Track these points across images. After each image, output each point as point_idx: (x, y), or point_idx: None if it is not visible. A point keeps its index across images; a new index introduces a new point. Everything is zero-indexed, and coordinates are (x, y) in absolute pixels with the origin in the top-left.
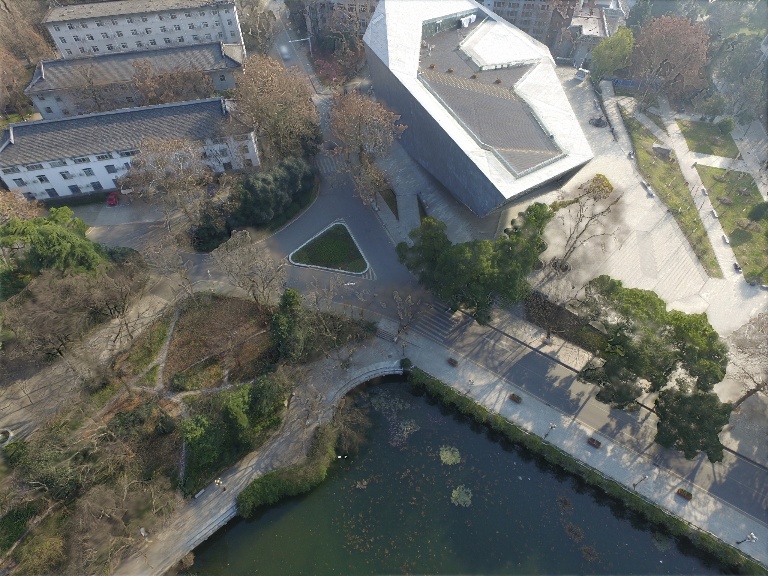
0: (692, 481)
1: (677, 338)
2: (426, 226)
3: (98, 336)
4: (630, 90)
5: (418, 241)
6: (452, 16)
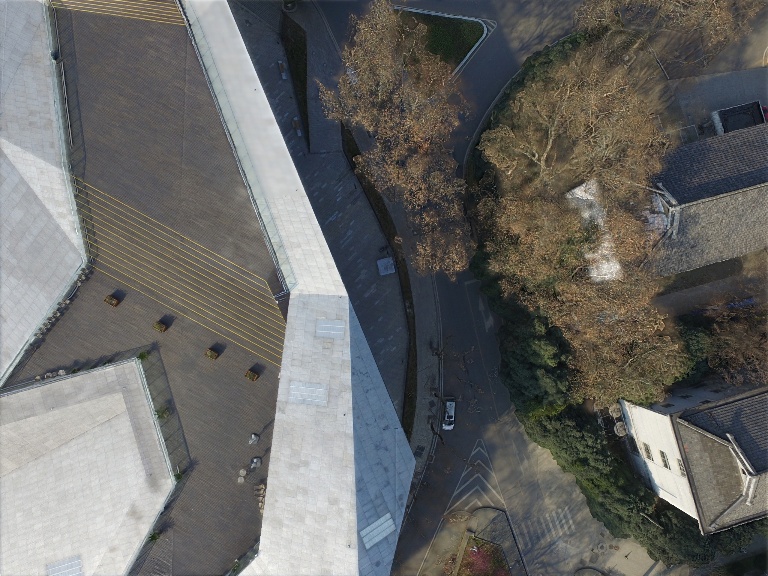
0: None
1: None
2: None
3: None
4: None
5: None
6: None
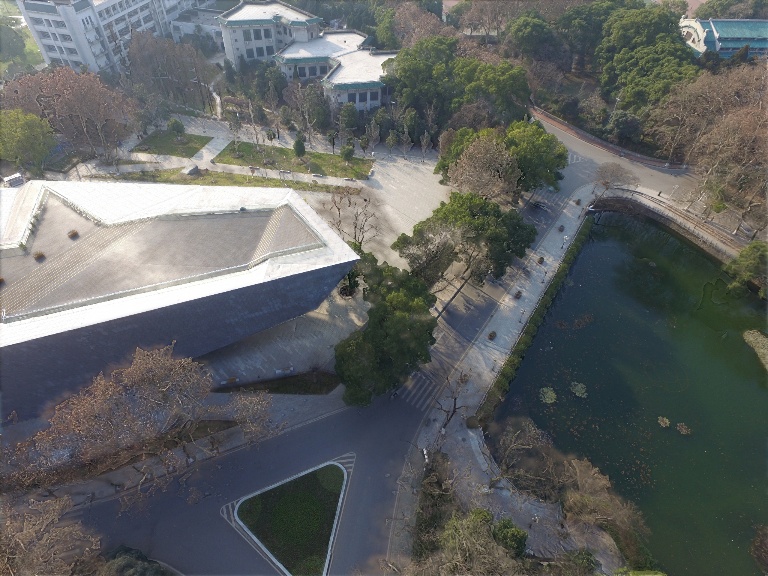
0: (530, 255)
1: (472, 212)
2: (359, 350)
3: None
4: (54, 163)
5: (369, 367)
6: None
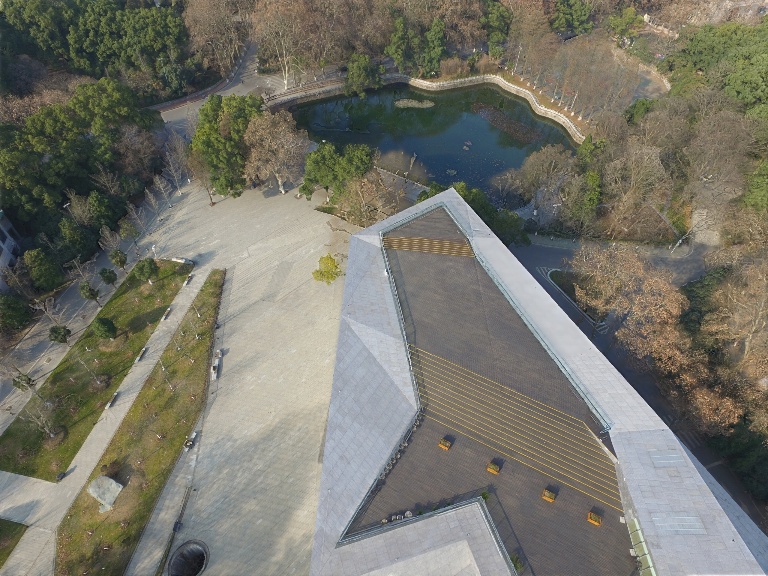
0: None
1: None
2: None
3: None
4: None
5: None
6: None
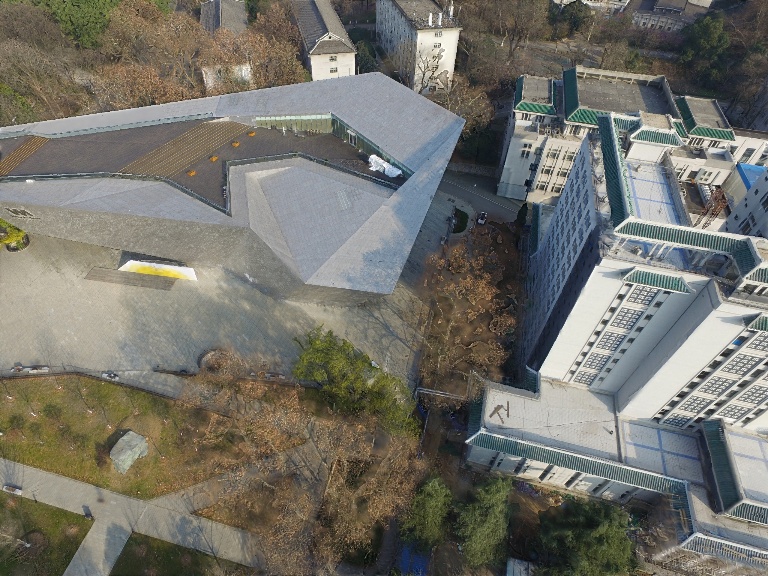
0: None
1: None
2: None
3: (88, 74)
4: None
5: None
6: (373, 145)
